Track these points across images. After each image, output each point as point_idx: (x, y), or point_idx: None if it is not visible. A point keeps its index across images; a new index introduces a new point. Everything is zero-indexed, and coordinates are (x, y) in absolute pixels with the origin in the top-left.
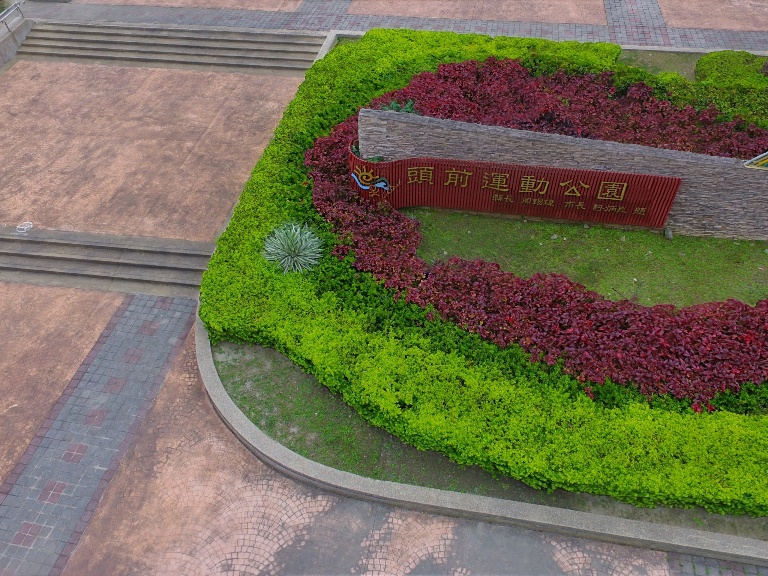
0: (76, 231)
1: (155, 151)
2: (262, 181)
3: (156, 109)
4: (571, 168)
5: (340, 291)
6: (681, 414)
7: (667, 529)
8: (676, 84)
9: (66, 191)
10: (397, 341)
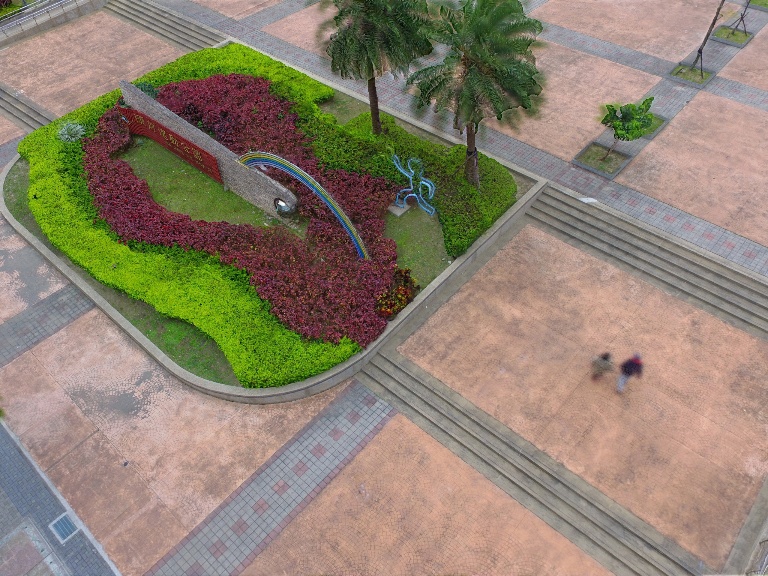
0: (33, 100)
1: (98, 76)
2: (97, 102)
3: (123, 56)
4: (184, 137)
5: (68, 154)
6: (112, 240)
7: (73, 273)
8: (319, 121)
9: (48, 82)
10: (61, 178)
